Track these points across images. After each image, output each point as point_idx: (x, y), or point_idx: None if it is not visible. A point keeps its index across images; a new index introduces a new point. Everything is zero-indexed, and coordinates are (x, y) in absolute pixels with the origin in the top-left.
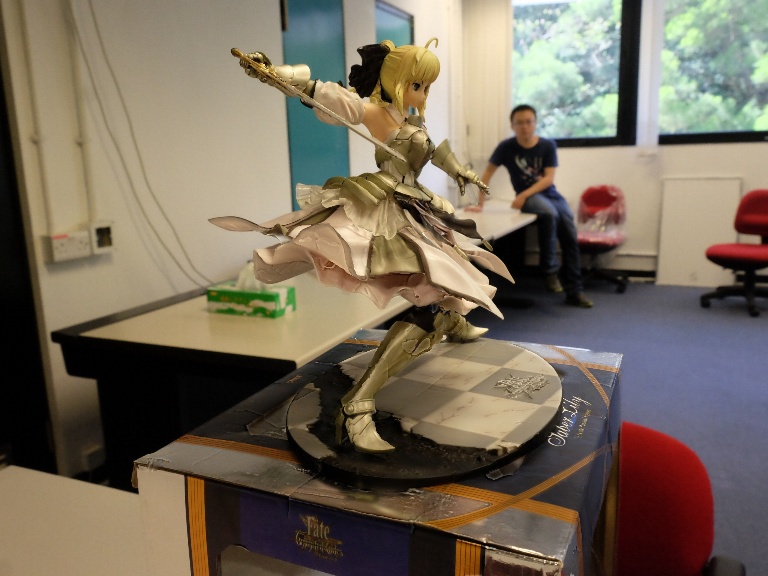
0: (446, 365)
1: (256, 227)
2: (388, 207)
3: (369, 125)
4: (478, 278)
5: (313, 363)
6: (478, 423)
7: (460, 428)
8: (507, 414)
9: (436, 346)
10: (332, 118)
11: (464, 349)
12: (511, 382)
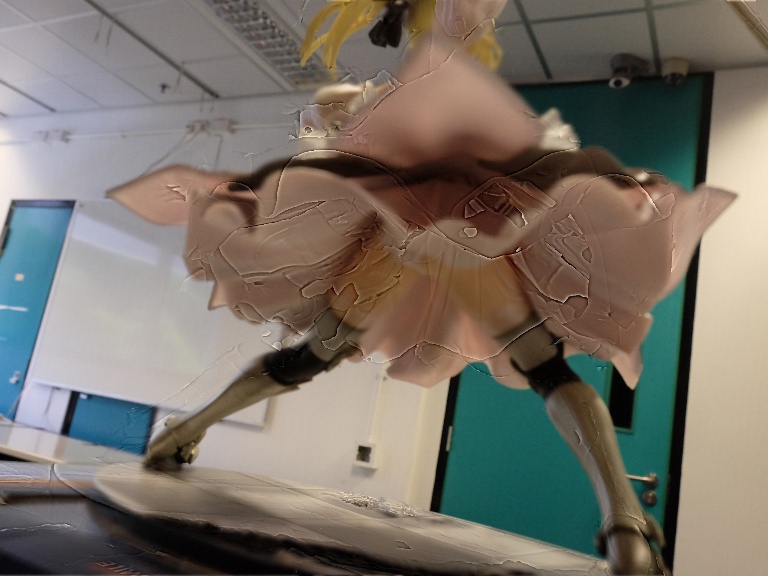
0: (242, 493)
1: (565, 120)
2: (525, 194)
3: (446, 47)
4: (377, 335)
5: (19, 530)
6: (504, 544)
7: (527, 552)
8: (472, 530)
9: (129, 469)
10: (497, 6)
11: (171, 471)
12: (364, 499)
